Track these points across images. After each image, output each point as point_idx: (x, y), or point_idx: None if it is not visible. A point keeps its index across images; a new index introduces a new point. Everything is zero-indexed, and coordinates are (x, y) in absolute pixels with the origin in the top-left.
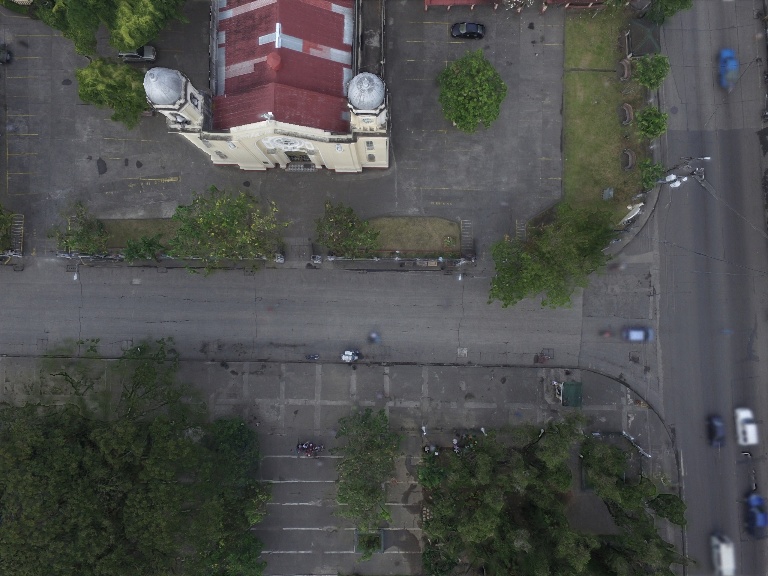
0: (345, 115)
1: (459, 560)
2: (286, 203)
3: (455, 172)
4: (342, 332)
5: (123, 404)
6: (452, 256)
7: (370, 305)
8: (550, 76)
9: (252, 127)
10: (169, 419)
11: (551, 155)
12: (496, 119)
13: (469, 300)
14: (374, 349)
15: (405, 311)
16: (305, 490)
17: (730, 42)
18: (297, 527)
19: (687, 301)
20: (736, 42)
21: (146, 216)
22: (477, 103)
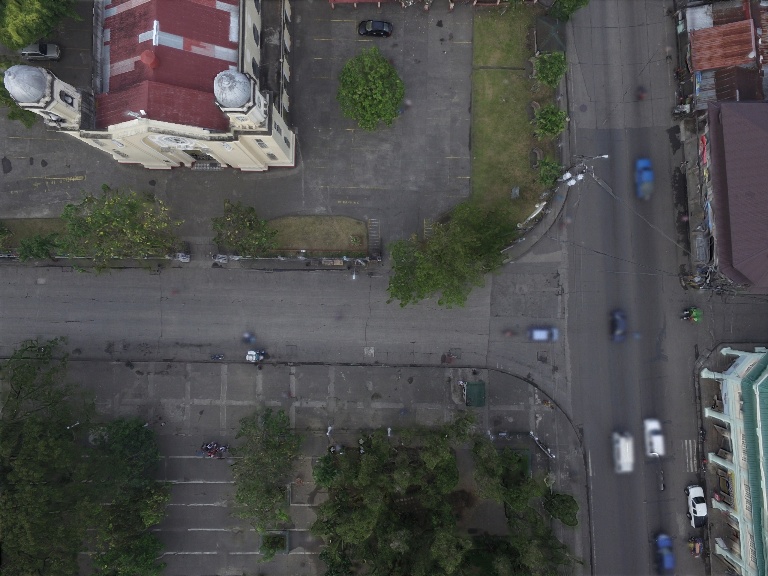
0: None
1: (365, 561)
2: (192, 202)
3: (362, 171)
4: (248, 332)
5: (10, 404)
6: (359, 255)
7: (276, 305)
8: (459, 74)
9: (126, 125)
10: (73, 419)
11: (459, 153)
12: (404, 117)
13: (376, 299)
14: (280, 349)
15: (311, 311)
16: (210, 491)
17: (640, 40)
18: (203, 528)
19: (595, 300)
20: (646, 40)
21: (51, 215)
22: (372, 101)
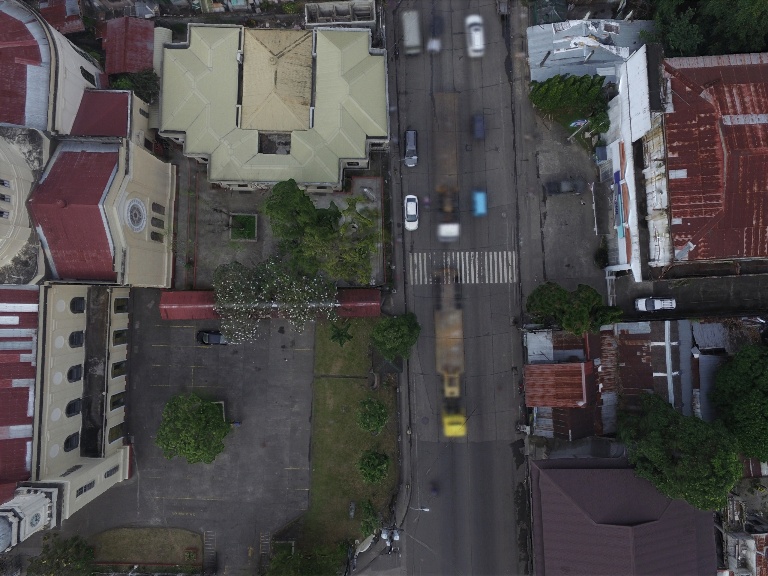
0: None
1: None
2: None
3: (199, 481)
4: None
5: None
6: (192, 571)
7: None
8: (299, 382)
9: None
10: None
11: (299, 464)
12: (243, 427)
13: None
14: None
15: None
16: None
17: (484, 350)
18: None
19: None
20: (491, 350)
21: None
22: None
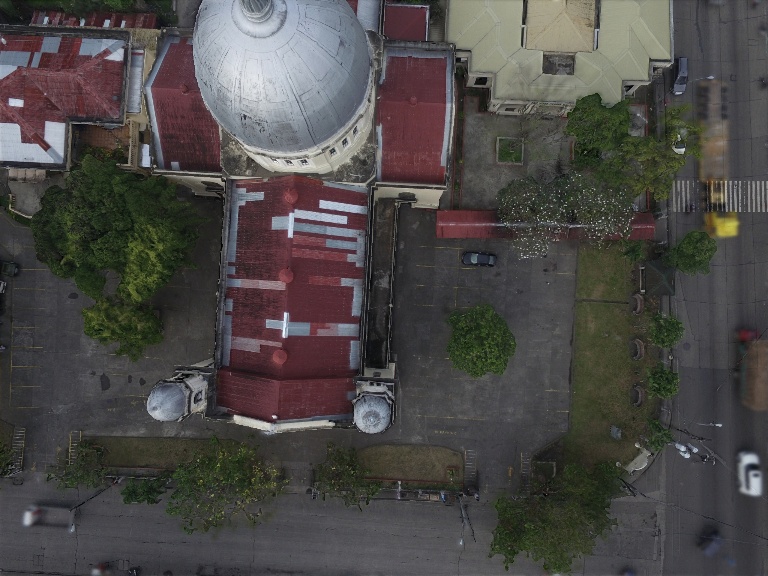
0: (350, 395)
1: None
2: None
3: (461, 401)
4: (340, 561)
5: None
6: (454, 488)
7: (369, 534)
8: (561, 306)
9: (255, 424)
10: None
11: (559, 387)
12: None
13: (470, 533)
14: None
15: (405, 542)
16: None
17: (746, 278)
18: None
19: (693, 544)
20: (753, 279)
21: (147, 434)
22: (485, 361)
